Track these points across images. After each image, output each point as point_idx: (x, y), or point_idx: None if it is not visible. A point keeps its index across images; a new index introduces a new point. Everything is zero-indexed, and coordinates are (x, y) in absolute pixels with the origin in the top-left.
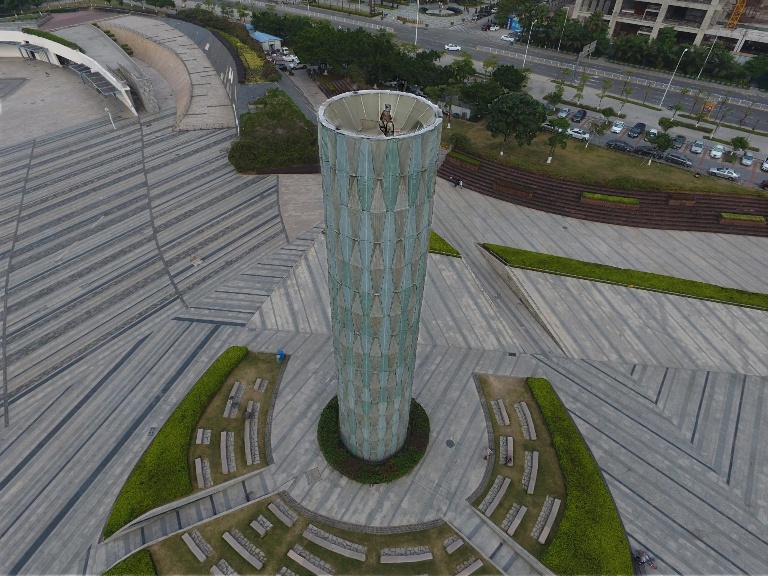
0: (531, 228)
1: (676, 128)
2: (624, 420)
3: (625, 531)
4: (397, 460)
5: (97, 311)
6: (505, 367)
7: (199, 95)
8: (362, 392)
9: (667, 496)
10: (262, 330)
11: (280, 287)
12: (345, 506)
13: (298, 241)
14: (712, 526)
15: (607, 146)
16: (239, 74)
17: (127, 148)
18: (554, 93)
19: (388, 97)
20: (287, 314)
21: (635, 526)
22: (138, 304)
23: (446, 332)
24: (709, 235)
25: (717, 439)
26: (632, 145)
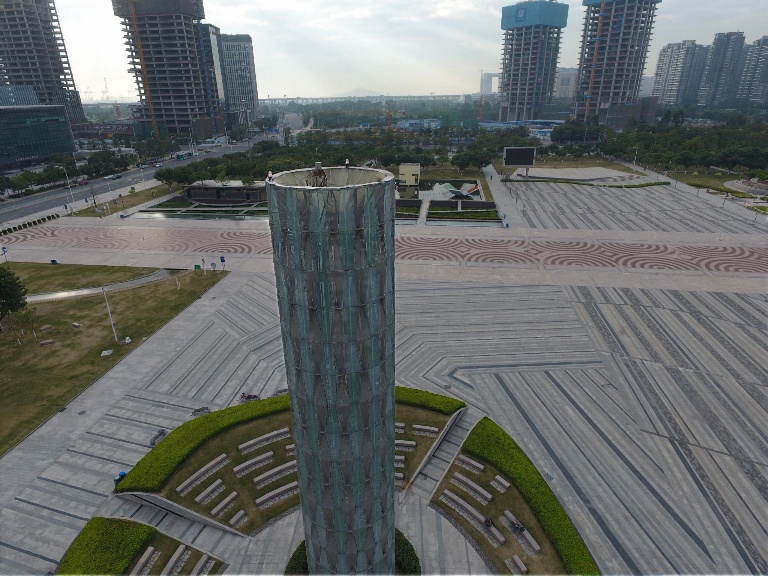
0: None
1: None
2: None
3: None
4: None
5: None
6: None
7: None
8: None
9: None
10: None
11: None
12: None
13: None
14: None
15: None
16: None
17: None
18: None
19: None
20: None
21: None
22: None
23: None
24: None
25: None
26: None
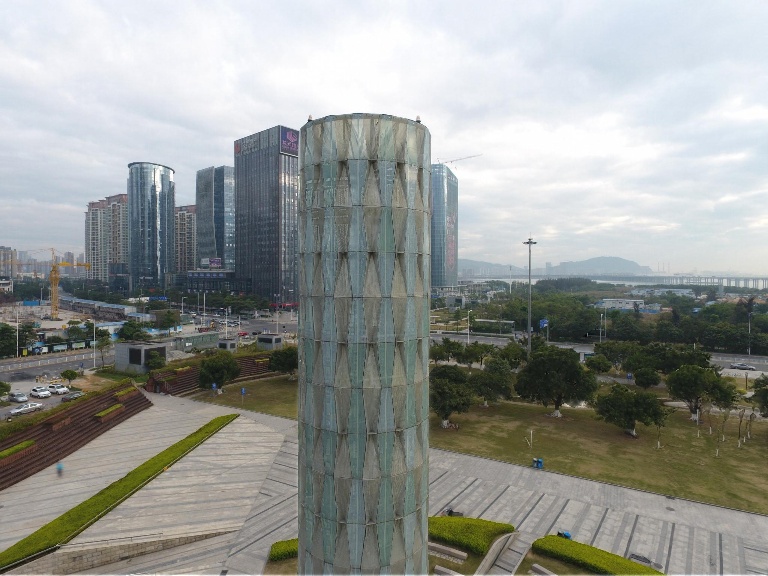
0: None
1: None
2: None
3: None
4: None
5: None
6: None
7: None
8: None
9: None
10: None
11: None
12: None
13: None
14: None
15: None
16: None
17: None
18: None
19: None
20: None
21: None
22: None
23: None
24: (109, 433)
25: None
26: None
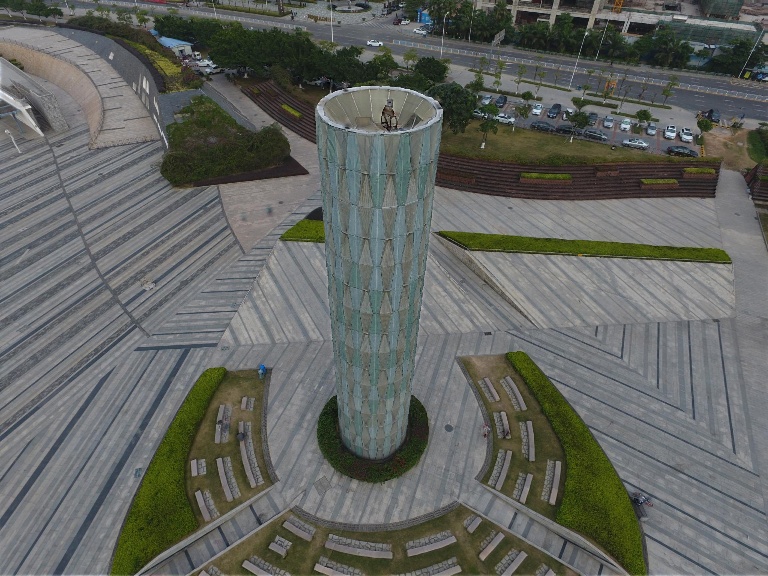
0: (480, 212)
1: (587, 106)
2: (598, 378)
3: (620, 478)
4: (403, 453)
5: (44, 354)
6: (484, 347)
7: (112, 108)
8: (370, 392)
9: (648, 440)
10: (236, 347)
11: (246, 300)
12: (361, 509)
13: (254, 251)
14: (689, 459)
15: (532, 128)
16: (157, 83)
17: (39, 172)
18: (476, 81)
19: (378, 93)
20: (259, 327)
21: (627, 472)
22: (91, 340)
23: (422, 322)
24: (634, 201)
25: (678, 381)
26: (553, 125)
